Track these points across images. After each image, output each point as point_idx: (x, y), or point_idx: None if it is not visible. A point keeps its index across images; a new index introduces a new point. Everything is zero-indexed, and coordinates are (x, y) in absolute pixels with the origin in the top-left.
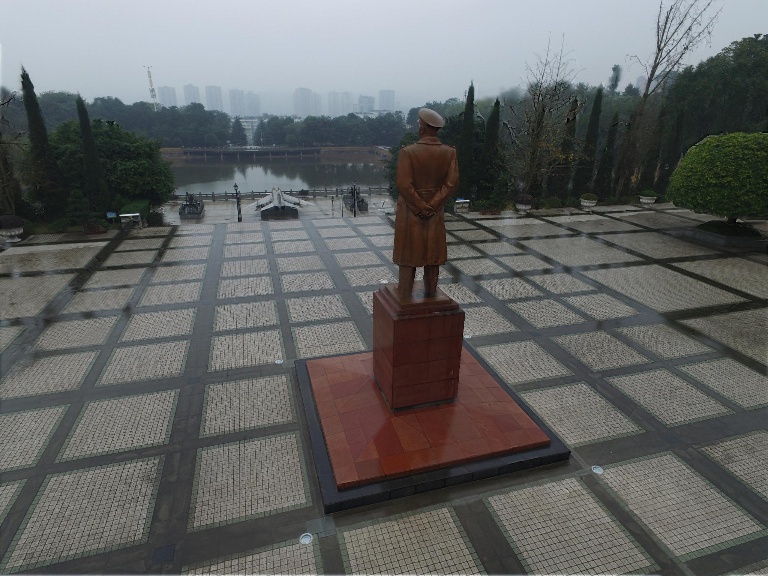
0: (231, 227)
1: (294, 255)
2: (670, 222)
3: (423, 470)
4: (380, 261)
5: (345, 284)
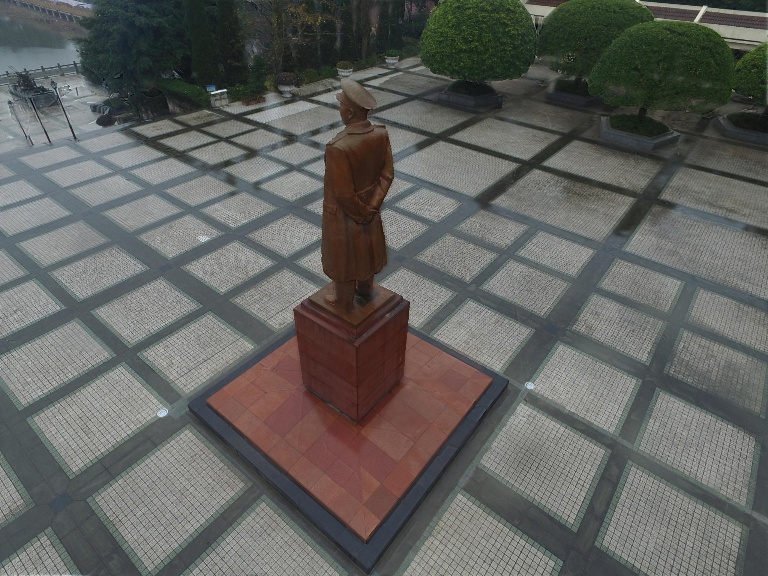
0: None
1: (43, 230)
2: (421, 84)
3: (422, 470)
4: (176, 208)
5: (157, 258)
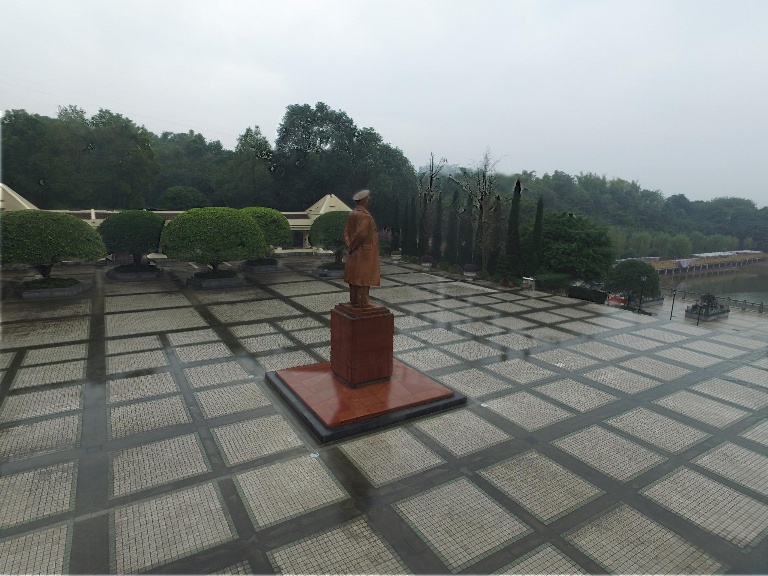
0: (588, 306)
1: (563, 330)
2: None
3: (291, 390)
4: (611, 358)
5: (529, 352)
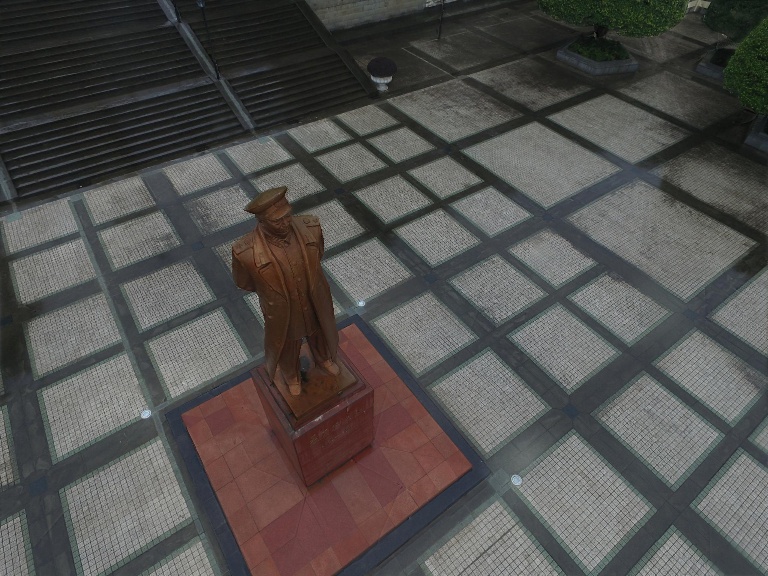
0: None
1: None
2: None
3: None
4: None
5: None
